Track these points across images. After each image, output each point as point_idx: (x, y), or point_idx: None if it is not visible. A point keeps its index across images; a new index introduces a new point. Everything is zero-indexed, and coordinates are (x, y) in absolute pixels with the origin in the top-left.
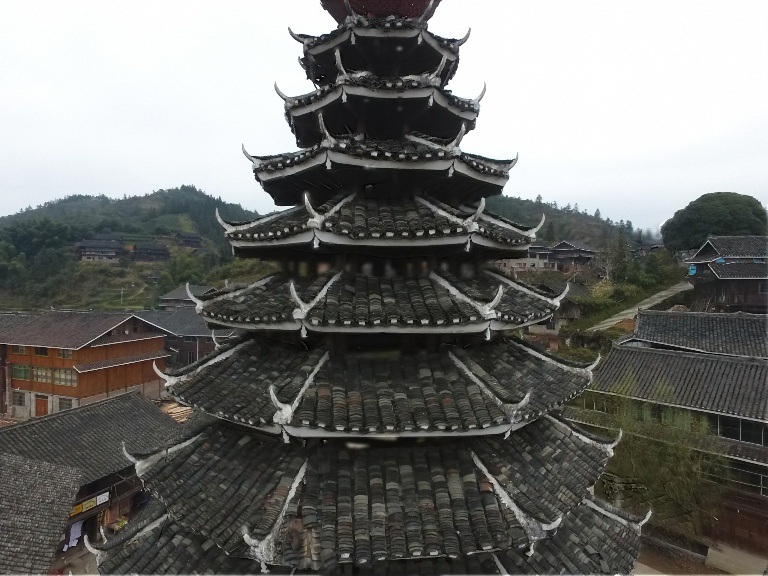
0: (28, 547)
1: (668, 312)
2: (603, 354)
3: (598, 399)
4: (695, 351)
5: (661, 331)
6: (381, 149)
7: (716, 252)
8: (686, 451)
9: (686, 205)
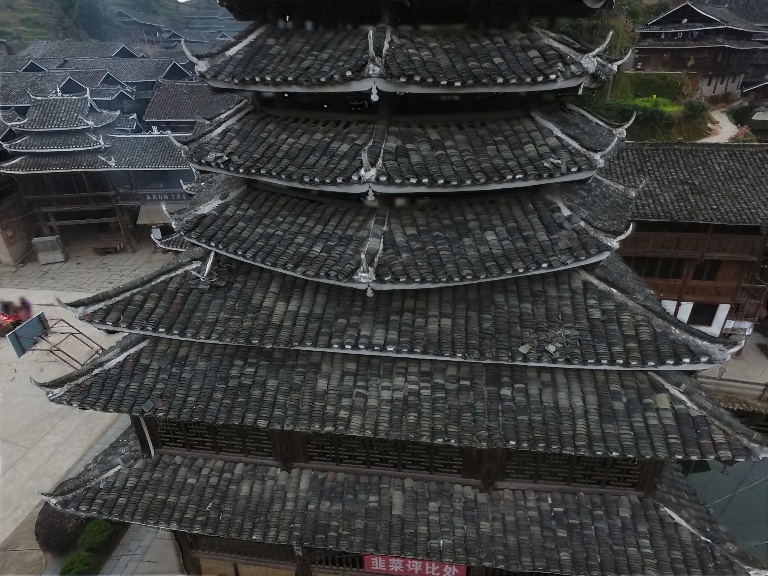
0: None
1: None
2: None
3: None
4: None
5: None
6: None
7: None
8: None
9: None
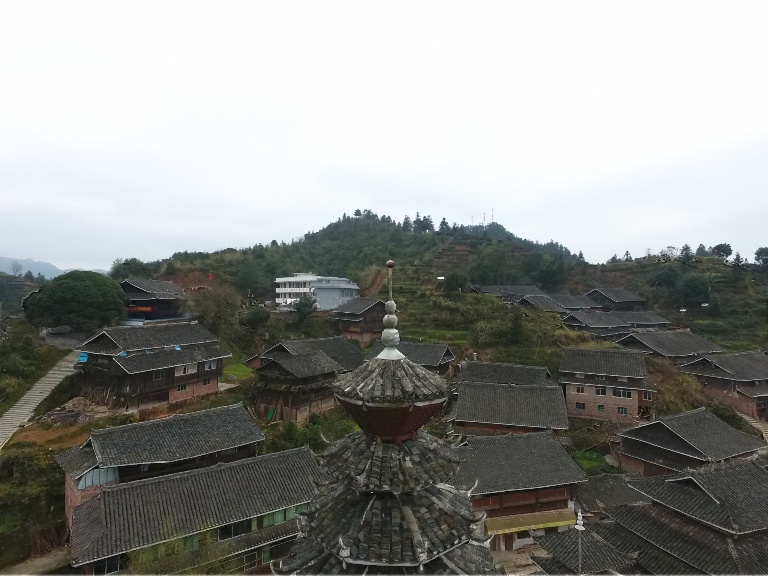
0: None
1: (120, 427)
2: (23, 484)
3: (113, 561)
4: (160, 464)
5: (124, 451)
6: (495, 574)
7: (117, 345)
8: (230, 575)
9: (51, 279)
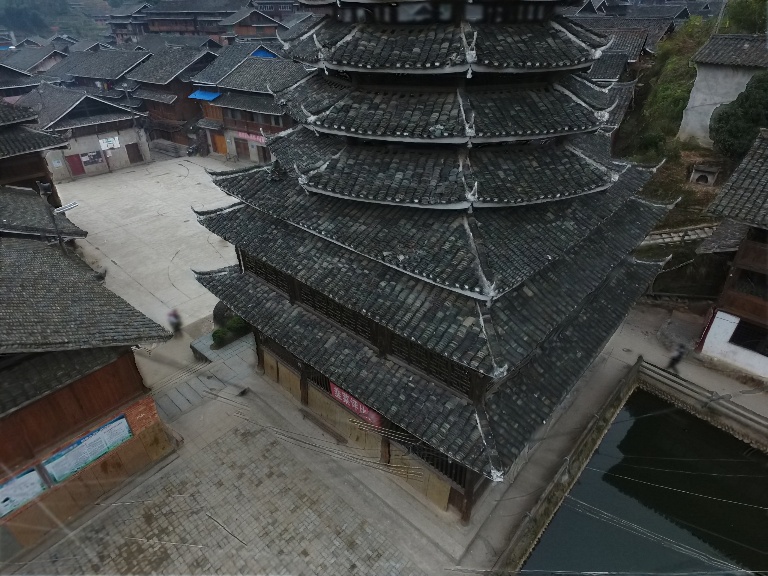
0: (764, 208)
1: None
2: None
3: None
4: None
5: None
6: None
7: None
8: None
9: None
